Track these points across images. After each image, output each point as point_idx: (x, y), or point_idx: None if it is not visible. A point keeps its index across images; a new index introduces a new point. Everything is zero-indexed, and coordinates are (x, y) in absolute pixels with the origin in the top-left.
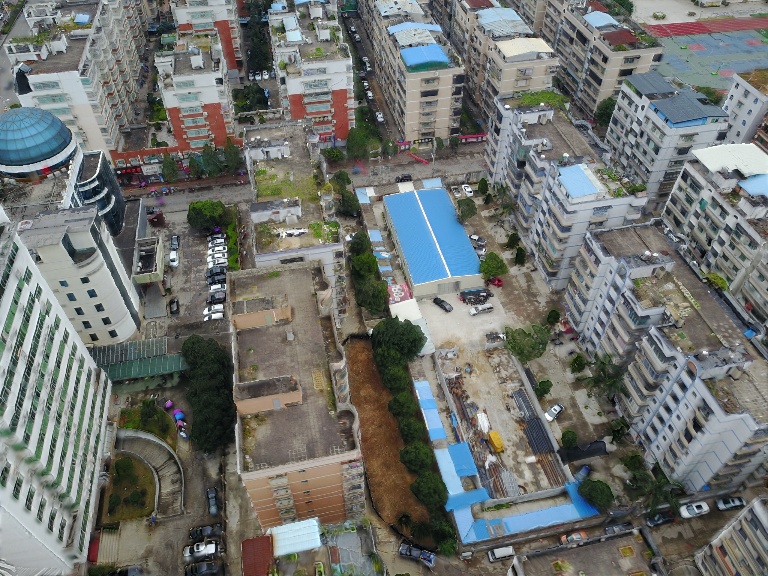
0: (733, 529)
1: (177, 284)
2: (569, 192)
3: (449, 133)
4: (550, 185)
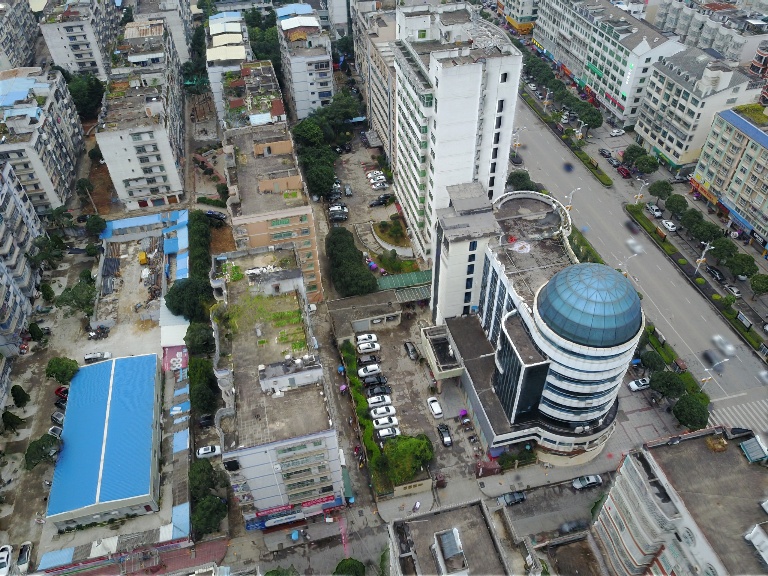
0: None
1: (420, 379)
2: None
3: None
4: None
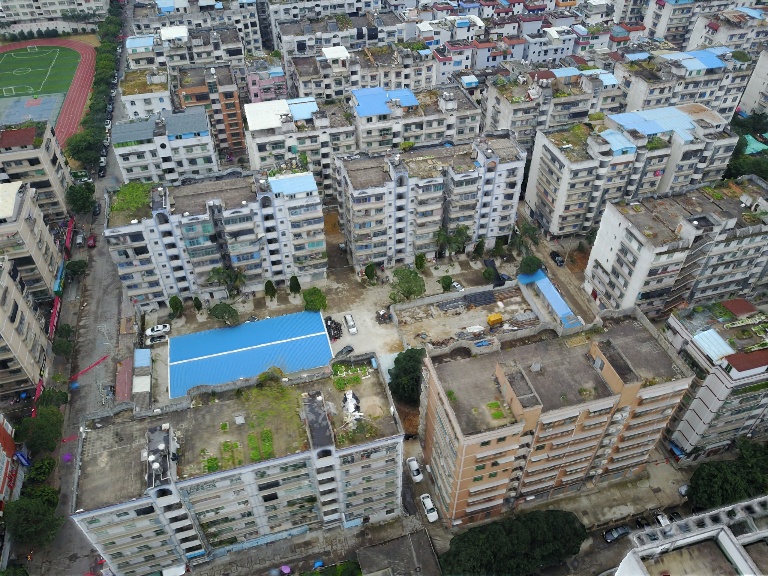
0: (568, 191)
1: None
2: (309, 190)
3: (44, 334)
4: (268, 214)
